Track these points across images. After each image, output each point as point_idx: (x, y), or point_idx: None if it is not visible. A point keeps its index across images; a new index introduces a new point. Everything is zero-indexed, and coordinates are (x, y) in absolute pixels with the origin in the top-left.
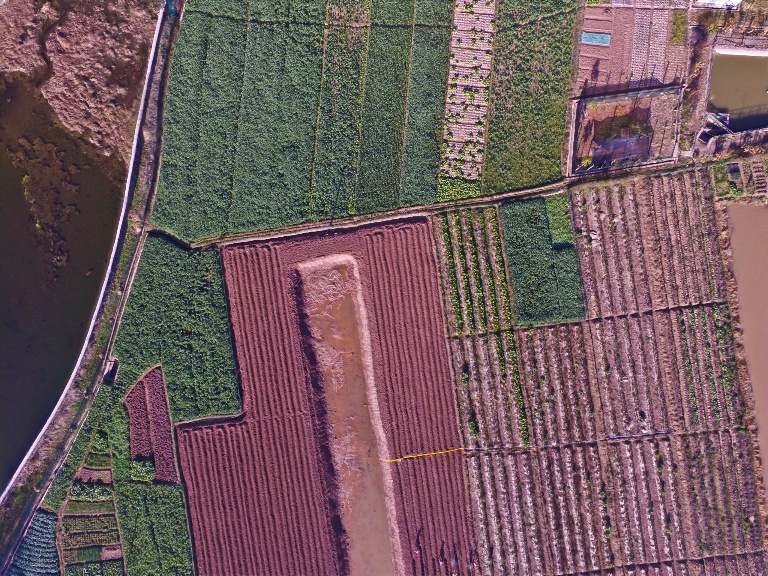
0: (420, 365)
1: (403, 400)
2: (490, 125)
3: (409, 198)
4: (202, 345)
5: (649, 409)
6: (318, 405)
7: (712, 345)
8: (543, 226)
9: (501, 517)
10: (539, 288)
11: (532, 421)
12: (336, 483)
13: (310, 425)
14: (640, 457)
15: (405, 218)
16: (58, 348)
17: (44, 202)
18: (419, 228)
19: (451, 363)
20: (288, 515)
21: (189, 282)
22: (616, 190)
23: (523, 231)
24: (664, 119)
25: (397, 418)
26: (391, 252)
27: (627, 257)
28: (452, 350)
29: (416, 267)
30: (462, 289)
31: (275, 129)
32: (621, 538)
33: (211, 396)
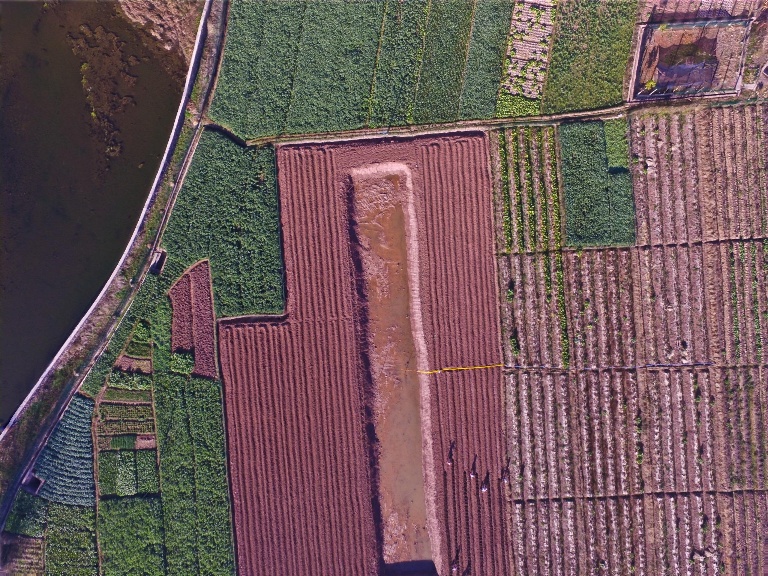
0: (466, 279)
1: (447, 312)
2: (555, 44)
3: (468, 111)
4: (251, 242)
5: (691, 339)
6: (361, 312)
7: (759, 280)
8: (600, 149)
9: (535, 436)
10: (591, 210)
11: (574, 343)
12: (373, 391)
13: (352, 330)
14: (678, 386)
15: (462, 132)
16: (105, 238)
17: (101, 91)
18: (476, 142)
19: (497, 279)
20: (324, 418)
21: (242, 179)
22: (676, 118)
23: (580, 152)
24: (730, 51)
25: (439, 330)
26: (446, 164)
27: (681, 186)
28: (499, 267)
29: (470, 181)
30: (514, 206)
31: (339, 31)
32: (653, 465)
33: (256, 294)
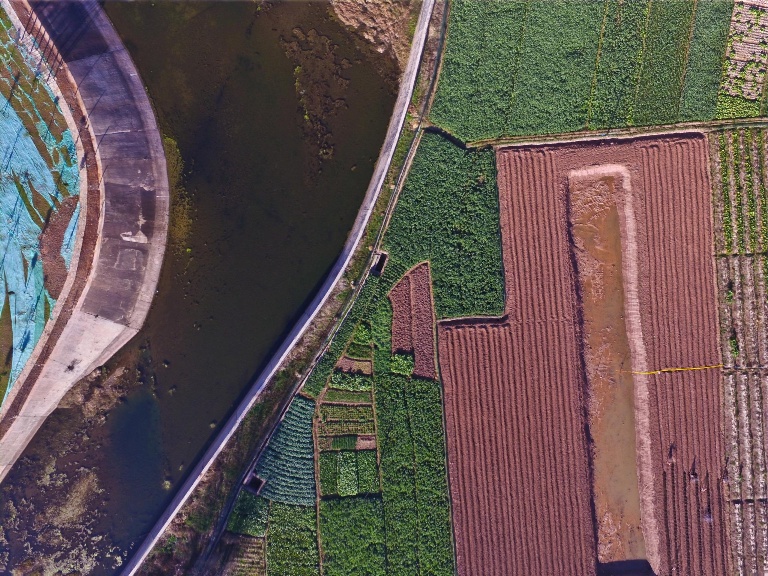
0: (686, 280)
1: (667, 313)
2: None
3: (689, 113)
4: (472, 244)
5: None
6: (579, 313)
7: None
8: None
9: (753, 436)
10: None
11: None
12: (588, 392)
13: (572, 331)
14: None
15: (680, 133)
16: (317, 241)
17: (314, 94)
18: (695, 144)
19: (716, 281)
20: (544, 418)
21: (463, 181)
22: None
23: None
24: None
25: (659, 331)
26: (666, 166)
27: None
28: (717, 268)
29: (690, 182)
30: (734, 208)
31: (561, 34)
32: None
33: (477, 295)
